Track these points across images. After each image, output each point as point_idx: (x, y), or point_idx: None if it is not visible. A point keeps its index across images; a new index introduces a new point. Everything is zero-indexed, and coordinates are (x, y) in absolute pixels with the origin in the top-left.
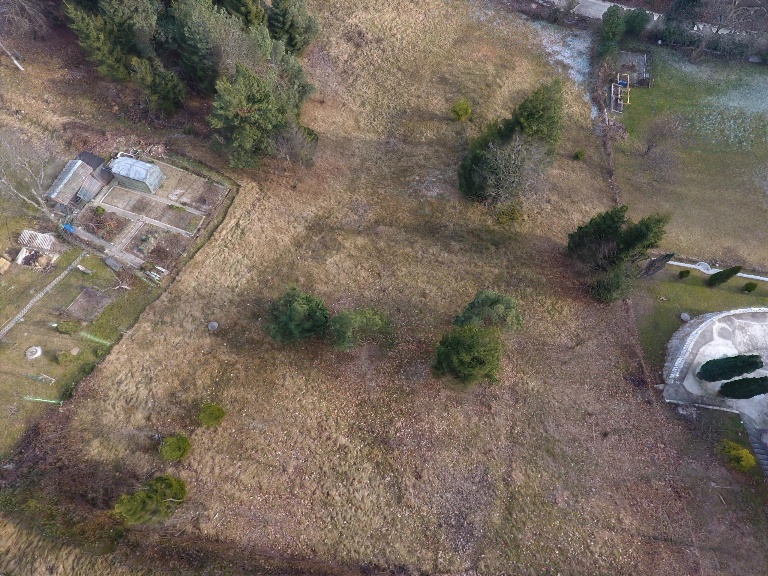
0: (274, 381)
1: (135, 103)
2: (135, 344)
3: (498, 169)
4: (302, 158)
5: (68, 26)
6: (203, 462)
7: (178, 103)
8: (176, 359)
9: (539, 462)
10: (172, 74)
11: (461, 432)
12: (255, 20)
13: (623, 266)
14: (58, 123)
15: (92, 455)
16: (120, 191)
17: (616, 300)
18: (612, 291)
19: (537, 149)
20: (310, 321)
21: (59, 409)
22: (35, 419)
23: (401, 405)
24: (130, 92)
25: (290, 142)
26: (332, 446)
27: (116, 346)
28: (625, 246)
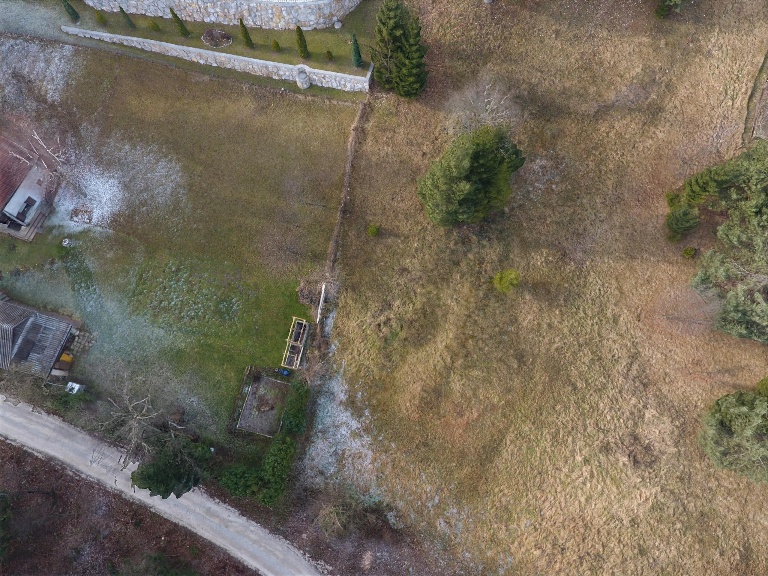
0: None
1: None
2: None
3: None
4: None
5: None
6: None
7: None
8: None
9: None
10: None
11: None
12: None
13: None
14: None
15: None
16: None
17: None
18: None
19: None
20: None
21: None
22: None
23: None
24: None
25: None
26: None
27: None
28: None
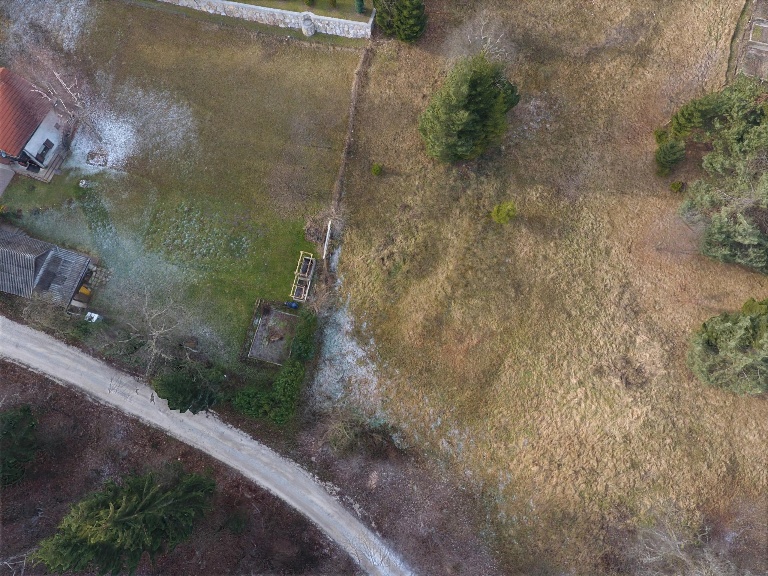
0: None
1: None
2: None
3: None
4: None
5: None
6: None
7: None
8: None
9: None
10: None
11: None
12: None
13: None
14: None
15: None
16: None
17: None
18: None
19: None
20: None
21: None
22: None
23: None
24: None
25: None
26: None
27: None
28: None
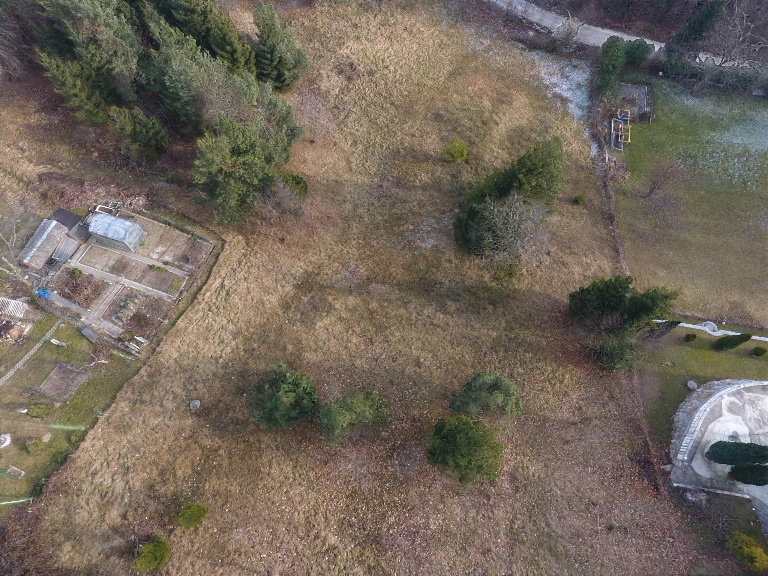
0: (259, 469)
1: (116, 148)
2: (112, 428)
3: (495, 227)
4: (291, 208)
5: (44, 68)
6: (182, 569)
7: (161, 148)
8: (155, 445)
9: (541, 563)
10: (153, 121)
11: (458, 528)
12: (241, 58)
13: (627, 335)
14: (34, 174)
15: (63, 562)
16: (98, 250)
17: (620, 369)
18: (616, 361)
19: (536, 200)
20: (297, 409)
21: (28, 509)
22: (2, 520)
23: (394, 496)
24: (110, 136)
25: (278, 194)
26: (321, 546)
27: (91, 431)
28: (629, 316)
